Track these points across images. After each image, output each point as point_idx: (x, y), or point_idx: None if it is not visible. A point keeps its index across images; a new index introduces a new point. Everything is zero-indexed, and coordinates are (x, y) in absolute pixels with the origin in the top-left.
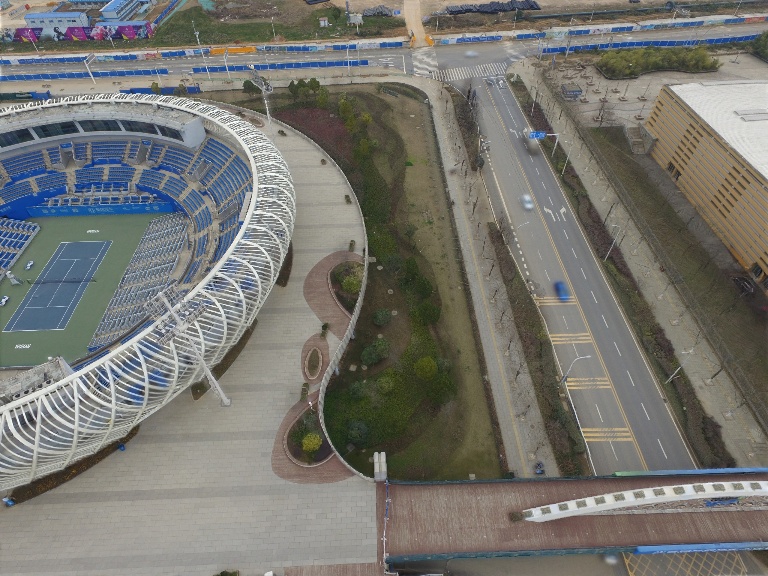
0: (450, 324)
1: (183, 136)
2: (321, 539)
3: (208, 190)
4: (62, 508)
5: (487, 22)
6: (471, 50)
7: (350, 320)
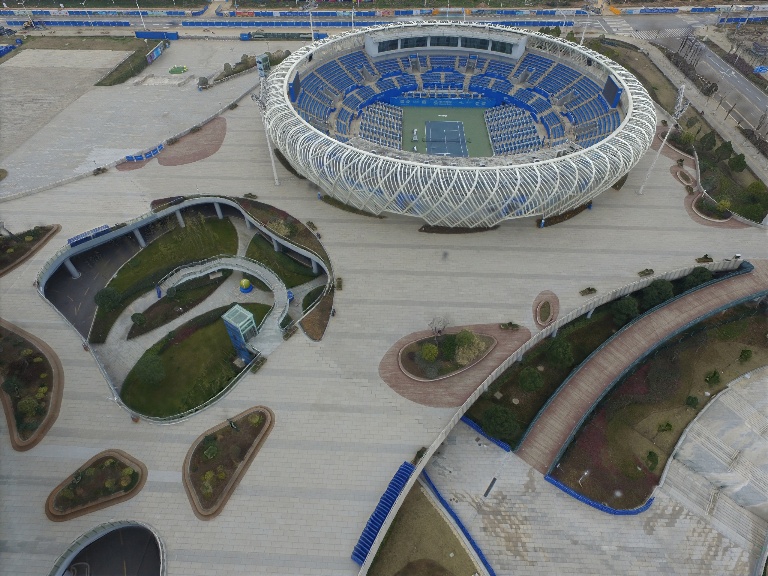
0: (742, 179)
1: (514, 49)
2: (751, 250)
3: None
4: (574, 230)
5: None
6: (654, 19)
7: (694, 159)
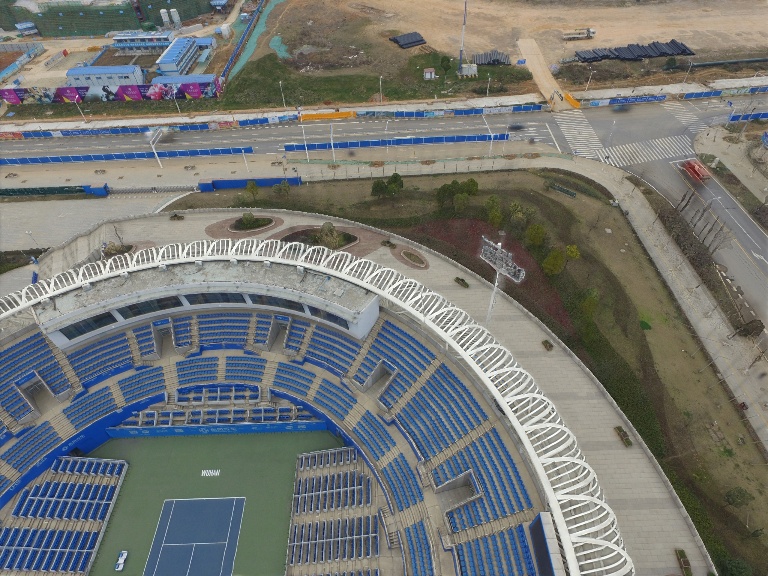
0: None
1: (351, 325)
2: None
3: (398, 420)
4: None
5: (632, 72)
6: (632, 115)
7: None
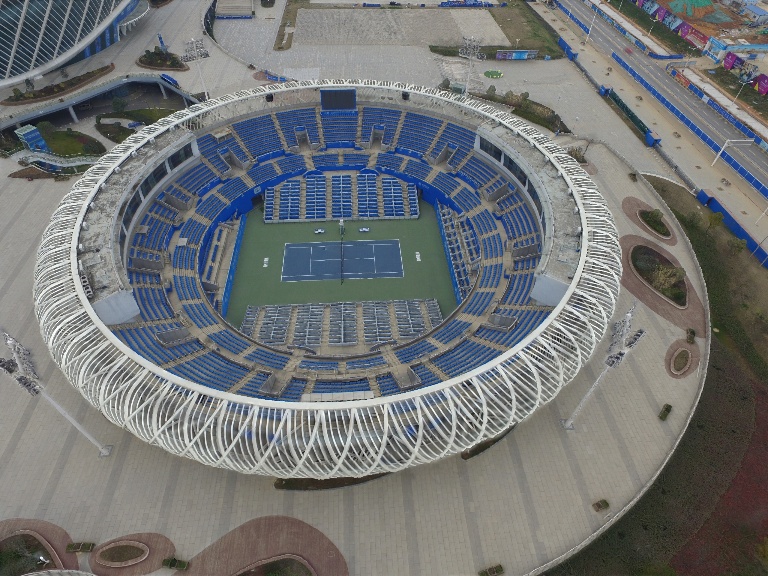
0: None
1: None
2: None
3: (464, 341)
4: None
5: None
6: None
7: None
